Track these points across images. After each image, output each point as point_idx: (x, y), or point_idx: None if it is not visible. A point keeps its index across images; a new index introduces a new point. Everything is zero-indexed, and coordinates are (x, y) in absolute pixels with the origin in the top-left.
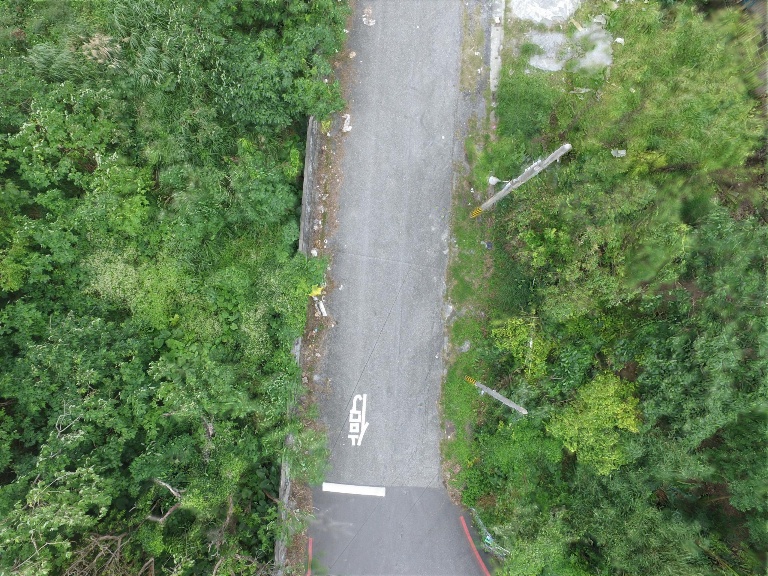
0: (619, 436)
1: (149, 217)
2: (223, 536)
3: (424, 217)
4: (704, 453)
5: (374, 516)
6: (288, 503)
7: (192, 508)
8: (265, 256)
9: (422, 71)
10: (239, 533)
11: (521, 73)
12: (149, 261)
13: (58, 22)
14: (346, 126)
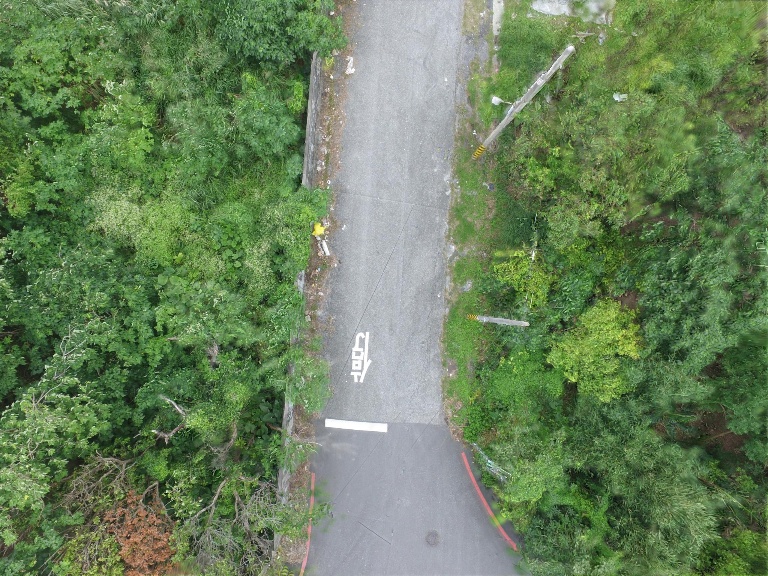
0: (620, 363)
1: (153, 156)
2: (227, 463)
3: (427, 158)
4: None
5: (376, 451)
6: (291, 438)
7: (196, 441)
8: (268, 195)
9: (425, 14)
10: (243, 462)
11: (524, 17)
12: (153, 200)
13: None
14: (349, 68)
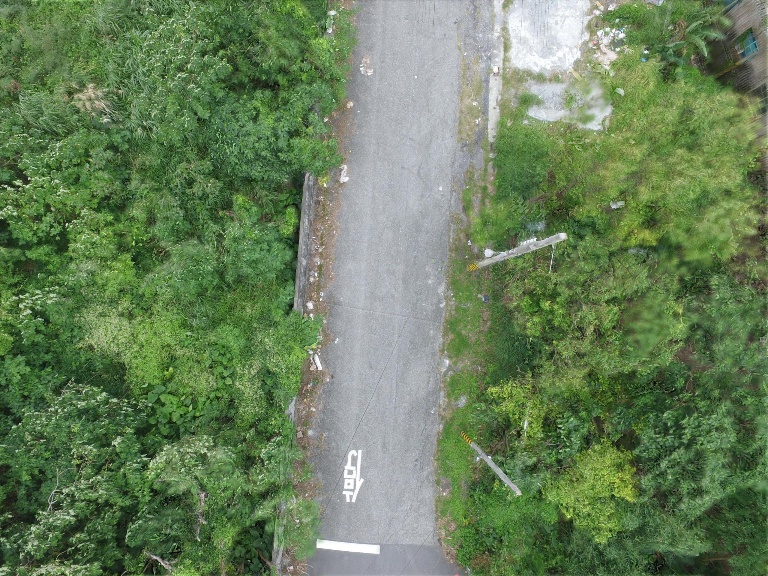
0: (615, 505)
1: (144, 270)
2: None
3: (421, 270)
4: (702, 521)
5: (368, 574)
6: (282, 560)
7: None
8: (260, 310)
9: (420, 122)
10: None
11: (519, 124)
12: (144, 314)
13: (55, 72)
14: (343, 177)
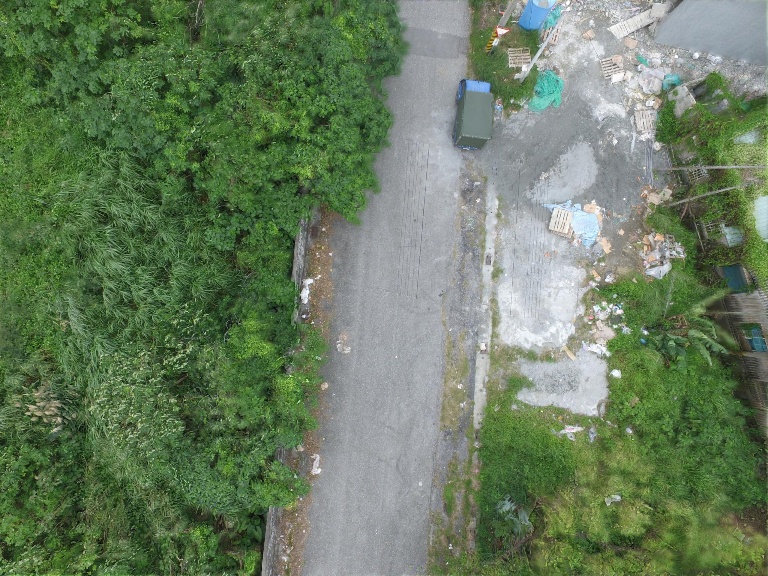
0: None
1: None
2: None
3: None
4: None
5: None
6: None
7: None
8: None
9: (399, 408)
10: None
11: (507, 410)
12: None
13: (6, 356)
14: (315, 468)
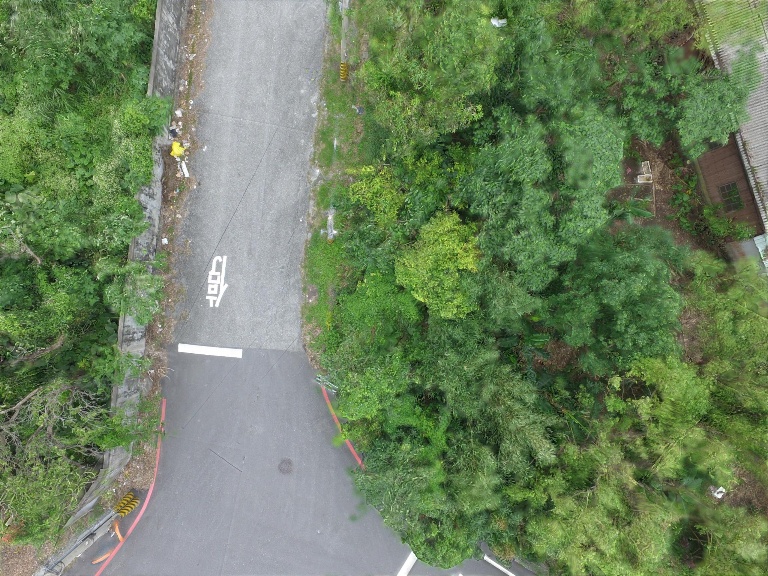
0: (459, 277)
1: (4, 69)
2: None
3: (293, 79)
4: (550, 301)
5: (229, 377)
6: (142, 363)
7: (38, 362)
8: None
9: None
10: (76, 379)
11: None
12: (5, 116)
13: None
14: None
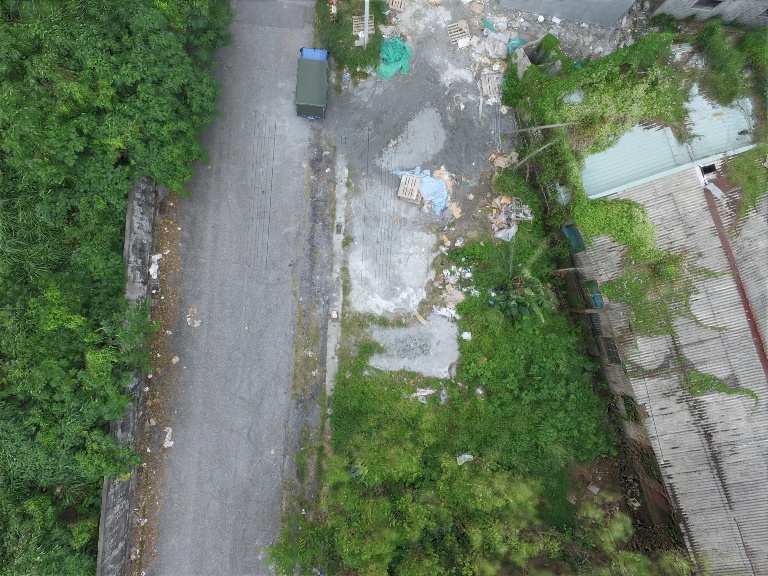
0: None
1: None
2: None
3: (250, 545)
4: None
5: None
6: None
7: None
8: None
9: (250, 378)
10: None
11: (359, 376)
12: None
13: None
14: (167, 441)
